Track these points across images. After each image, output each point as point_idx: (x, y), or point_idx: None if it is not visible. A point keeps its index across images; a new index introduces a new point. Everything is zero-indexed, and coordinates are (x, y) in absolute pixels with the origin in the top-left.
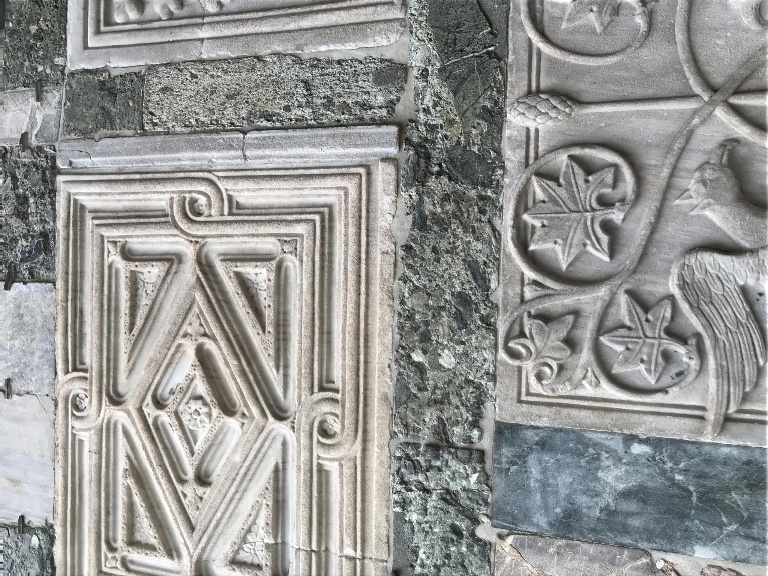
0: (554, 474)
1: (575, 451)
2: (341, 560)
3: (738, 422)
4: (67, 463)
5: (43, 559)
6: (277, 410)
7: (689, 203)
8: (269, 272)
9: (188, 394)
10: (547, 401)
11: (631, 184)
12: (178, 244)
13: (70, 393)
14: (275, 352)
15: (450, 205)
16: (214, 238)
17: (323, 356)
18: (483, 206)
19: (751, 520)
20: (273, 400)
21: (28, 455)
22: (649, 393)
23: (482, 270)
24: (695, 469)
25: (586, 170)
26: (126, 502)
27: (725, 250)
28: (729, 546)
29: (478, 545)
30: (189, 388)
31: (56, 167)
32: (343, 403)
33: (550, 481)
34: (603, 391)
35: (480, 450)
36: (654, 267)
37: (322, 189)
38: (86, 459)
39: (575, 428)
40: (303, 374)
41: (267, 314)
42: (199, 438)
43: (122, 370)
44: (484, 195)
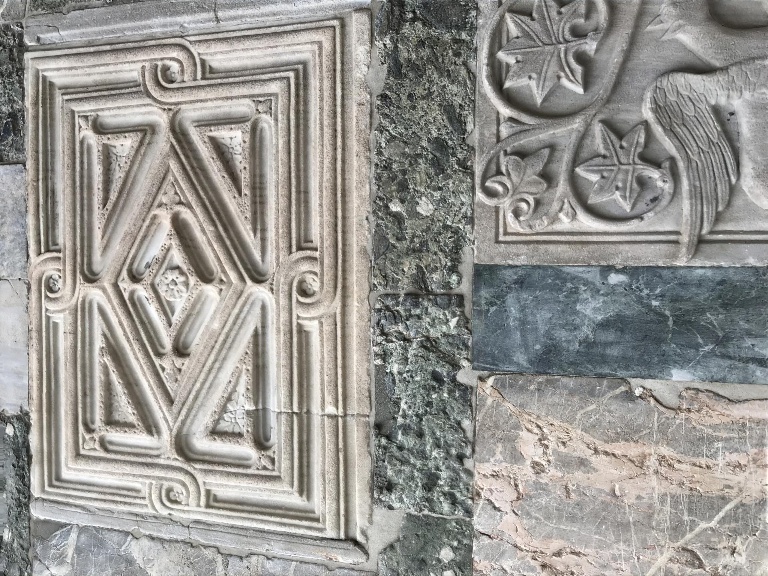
0: (533, 311)
1: (553, 287)
2: (323, 419)
3: (712, 243)
4: (41, 346)
5: (19, 447)
6: (255, 274)
7: (660, 29)
8: (244, 134)
9: (164, 265)
10: (525, 239)
11: (603, 13)
12: (151, 114)
13: (43, 275)
14: (252, 215)
15: (424, 51)
16: (187, 104)
17: (300, 215)
18: (457, 49)
19: (726, 339)
20: (251, 264)
21: (1, 341)
22: (625, 220)
23: (458, 114)
24: (671, 294)
25: (558, 4)
26: (103, 380)
27: (696, 72)
28: (706, 367)
29: (459, 390)
30: (165, 259)
31: (24, 45)
32: (322, 260)
33: (529, 318)
34: (580, 224)
35: (459, 295)
36: (627, 96)
37: (296, 45)
38: (61, 342)
39: (553, 264)
40: (281, 234)
41: (243, 176)
42: (176, 308)
43: (96, 248)
44: (458, 39)
